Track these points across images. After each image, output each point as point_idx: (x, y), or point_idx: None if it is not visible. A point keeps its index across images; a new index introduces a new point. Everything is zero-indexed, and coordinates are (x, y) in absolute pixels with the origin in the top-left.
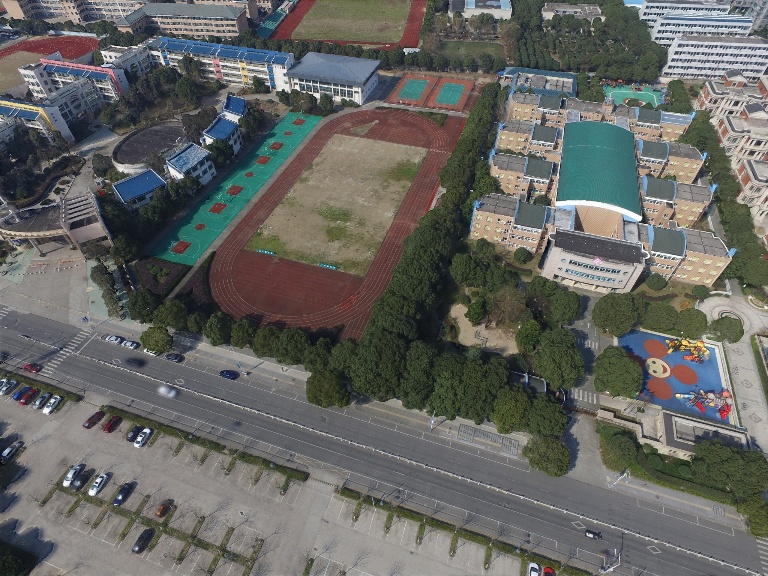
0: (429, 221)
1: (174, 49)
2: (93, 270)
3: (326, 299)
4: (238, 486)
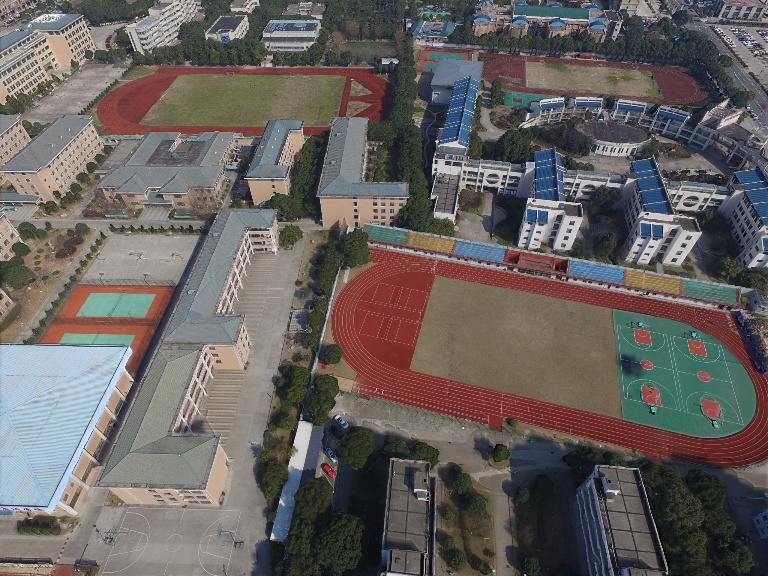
0: (624, 42)
1: None
2: (738, 120)
3: None
4: (767, 82)
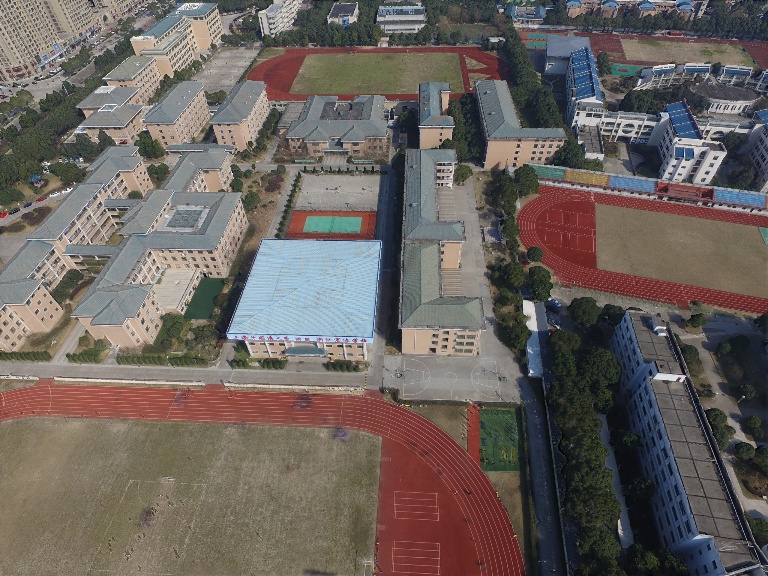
0: (714, 19)
1: (600, 95)
2: None
3: (764, 49)
4: None
